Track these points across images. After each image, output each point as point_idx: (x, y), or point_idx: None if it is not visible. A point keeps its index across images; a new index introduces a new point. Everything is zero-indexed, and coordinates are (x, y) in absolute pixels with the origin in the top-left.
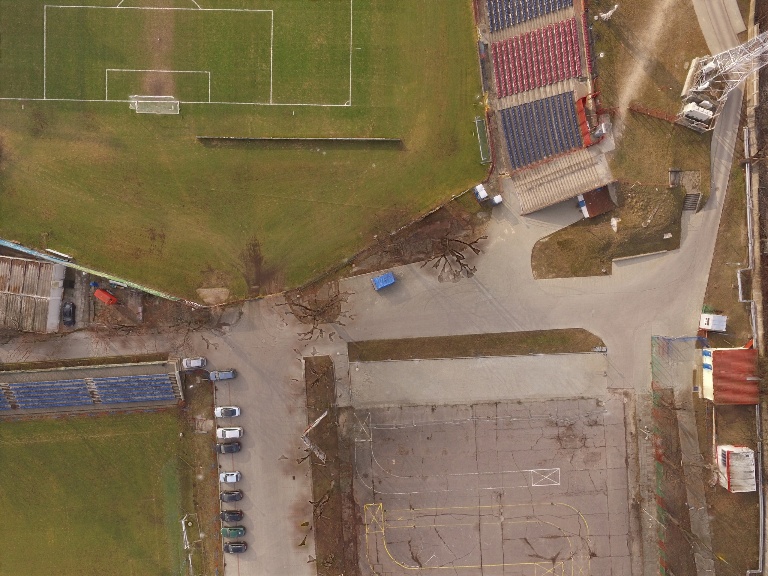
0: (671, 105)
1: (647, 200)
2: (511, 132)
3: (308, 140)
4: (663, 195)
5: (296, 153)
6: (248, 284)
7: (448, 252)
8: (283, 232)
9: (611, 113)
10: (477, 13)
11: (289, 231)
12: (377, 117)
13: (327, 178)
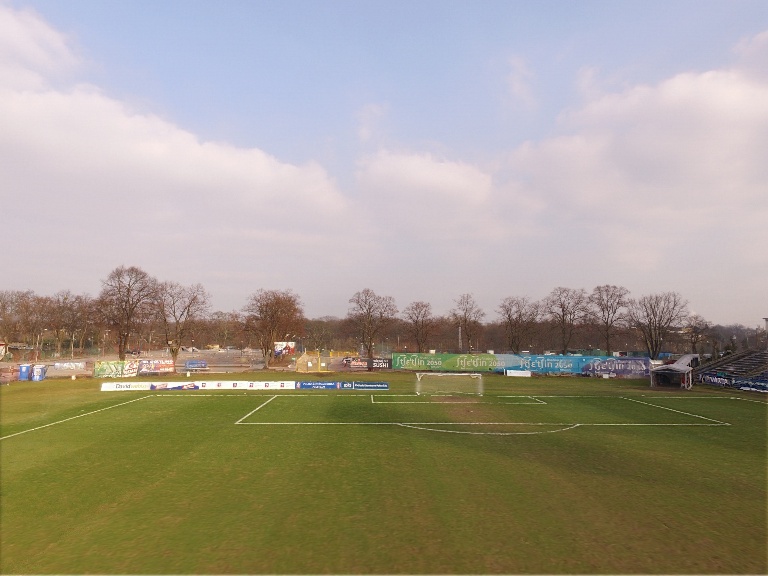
0: None
1: None
2: None
3: (234, 388)
4: None
5: None
6: (331, 373)
7: None
8: None
9: None
10: None
11: None
12: None
13: None
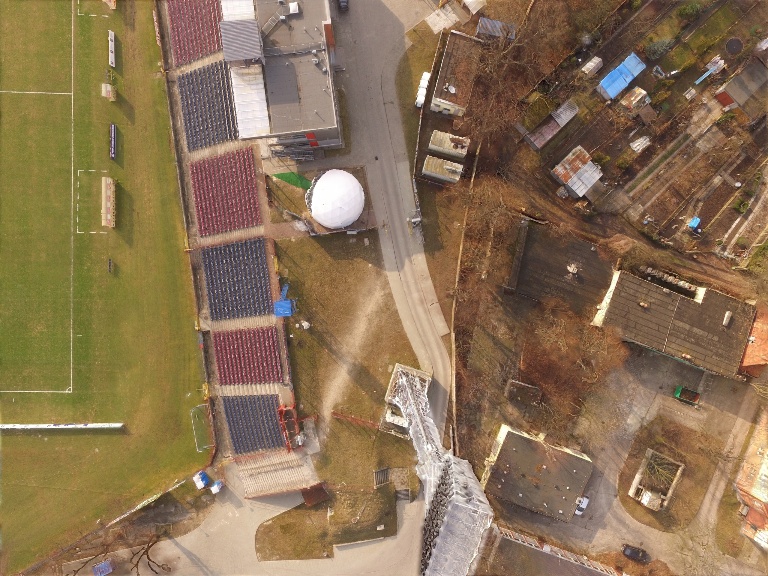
0: (375, 408)
1: (354, 499)
2: (231, 419)
3: None
4: (369, 495)
5: (17, 439)
6: None
7: (172, 536)
8: (5, 517)
9: (315, 417)
10: (200, 299)
11: (11, 516)
12: (99, 402)
13: (49, 463)
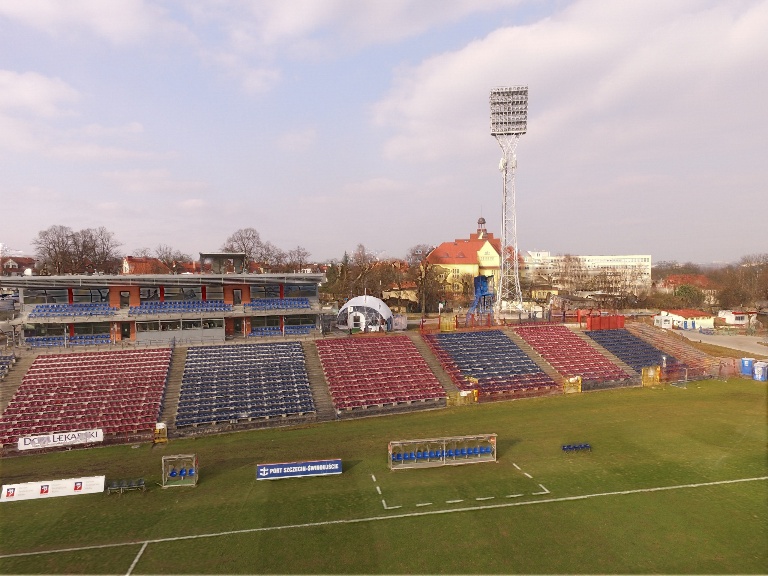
0: None
1: None
2: None
3: None
4: None
5: None
6: None
7: None
8: None
9: None
10: None
11: None
12: None
13: None
